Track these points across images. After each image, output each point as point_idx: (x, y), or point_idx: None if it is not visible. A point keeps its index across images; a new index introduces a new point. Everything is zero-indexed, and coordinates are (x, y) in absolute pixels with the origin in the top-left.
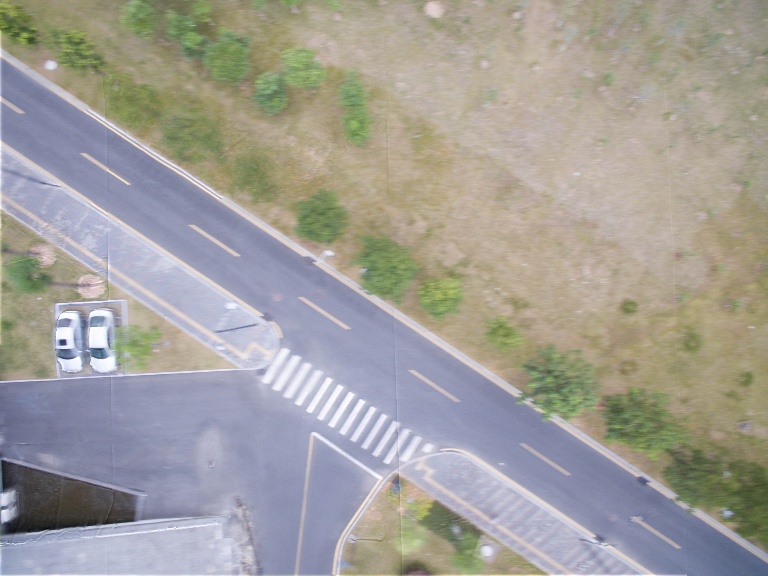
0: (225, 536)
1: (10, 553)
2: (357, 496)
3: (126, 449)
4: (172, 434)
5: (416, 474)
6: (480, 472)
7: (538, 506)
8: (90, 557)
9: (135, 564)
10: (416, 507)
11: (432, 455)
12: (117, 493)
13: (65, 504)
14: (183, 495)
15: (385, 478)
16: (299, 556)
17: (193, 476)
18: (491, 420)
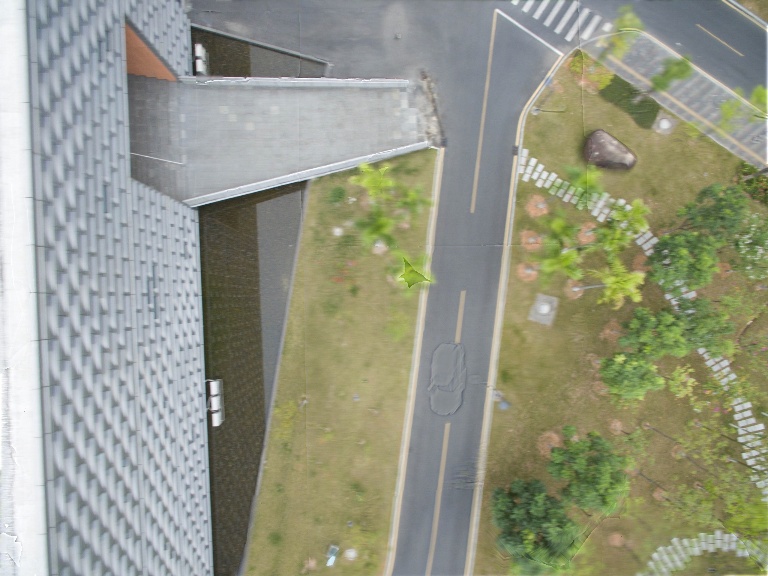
0: (410, 106)
1: (207, 96)
2: (539, 71)
3: (313, 20)
4: (358, 7)
5: (597, 51)
6: (658, 50)
7: (714, 83)
8: (283, 110)
9: (326, 121)
10: (599, 77)
11: (611, 34)
12: (304, 62)
13: (255, 64)
14: (369, 66)
15: (566, 54)
16: (483, 127)
17: (379, 48)
18: (668, 2)
